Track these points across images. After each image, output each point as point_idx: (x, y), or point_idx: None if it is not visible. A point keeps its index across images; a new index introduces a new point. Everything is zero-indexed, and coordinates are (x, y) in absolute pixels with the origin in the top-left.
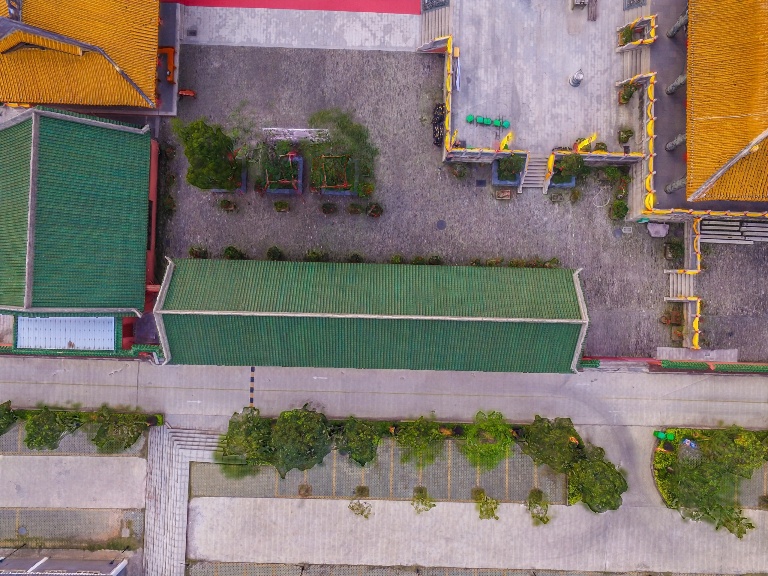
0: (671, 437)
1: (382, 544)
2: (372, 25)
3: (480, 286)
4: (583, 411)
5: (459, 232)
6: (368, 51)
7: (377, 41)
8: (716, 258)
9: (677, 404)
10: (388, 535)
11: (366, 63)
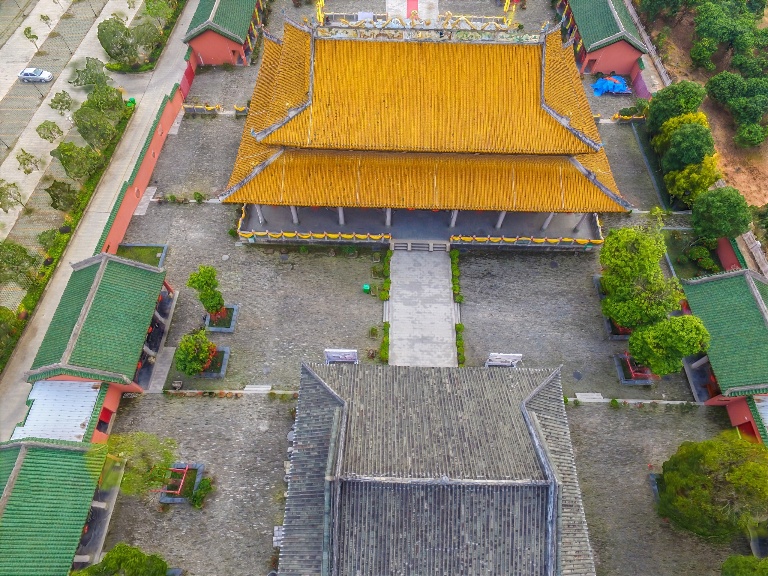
0: (129, 104)
1: (116, 7)
2: (400, 6)
3: (241, 5)
4: (161, 76)
5: (281, 32)
6: (385, 5)
7: (391, 8)
8: (243, 125)
9: (150, 114)
10: (120, 8)
11: (379, 4)
